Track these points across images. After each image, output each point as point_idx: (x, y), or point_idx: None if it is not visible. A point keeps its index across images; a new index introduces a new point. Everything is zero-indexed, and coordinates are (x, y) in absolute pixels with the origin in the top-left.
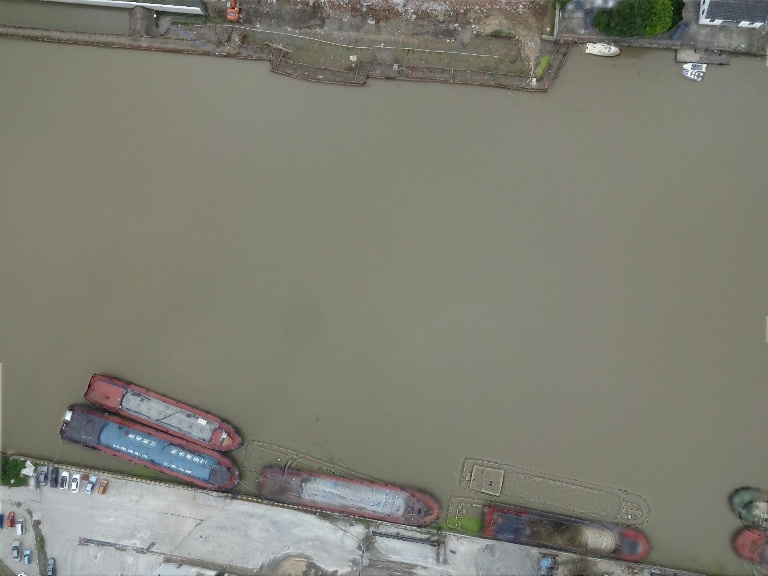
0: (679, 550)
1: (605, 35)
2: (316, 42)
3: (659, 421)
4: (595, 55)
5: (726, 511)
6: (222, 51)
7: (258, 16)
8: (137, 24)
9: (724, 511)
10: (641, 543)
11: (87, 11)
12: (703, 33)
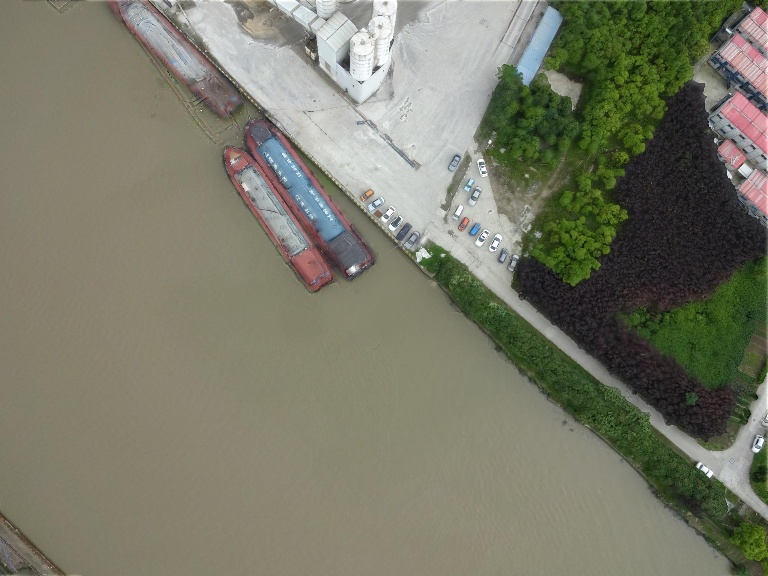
0: None
1: None
2: None
3: None
4: None
5: None
6: None
7: None
8: None
9: None
10: None
11: None
12: None
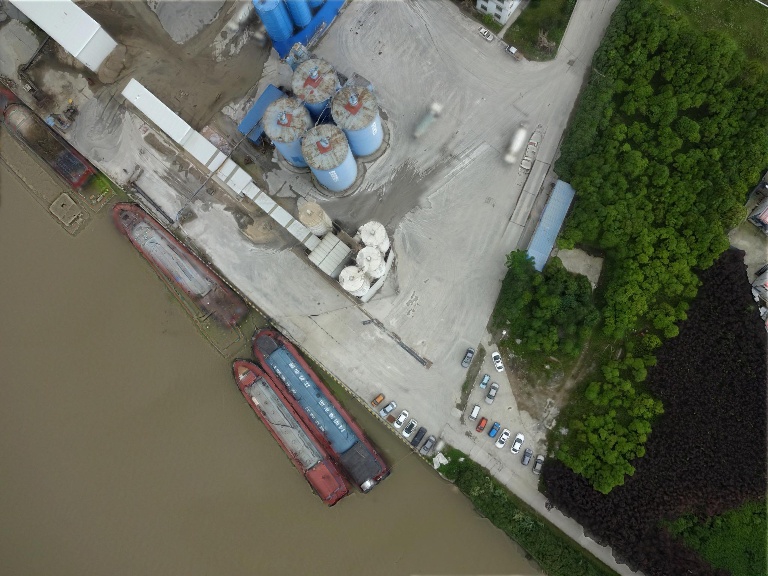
0: None
1: None
2: None
3: None
4: None
5: None
6: None
7: None
8: None
9: None
10: None
11: None
12: None
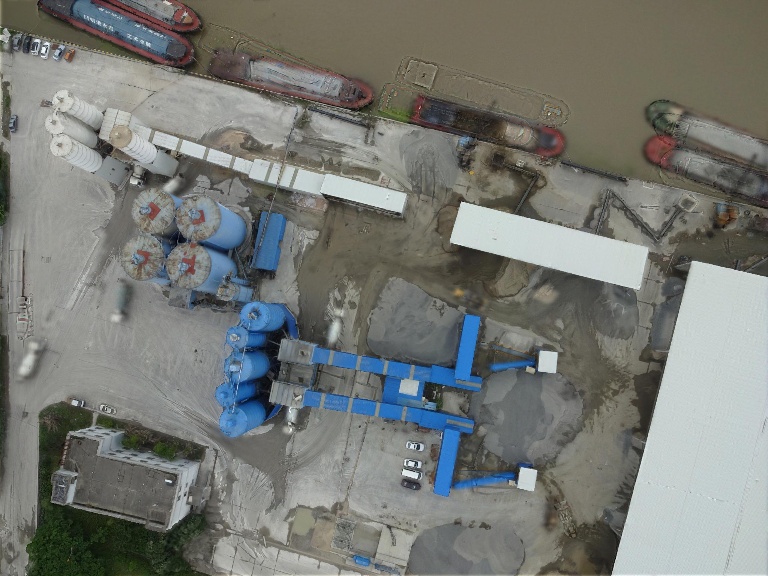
0: (593, 156)
1: None
2: None
3: (589, 36)
4: None
5: (641, 117)
6: None
7: None
8: None
9: (639, 118)
10: (557, 142)
11: None
12: None
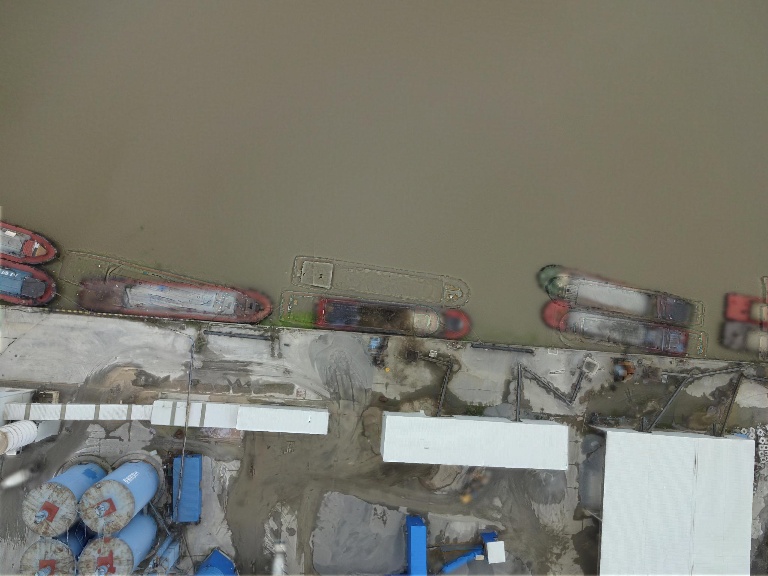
0: (498, 328)
1: None
2: None
3: (474, 211)
4: None
5: (535, 286)
6: None
7: None
8: None
9: (533, 286)
10: (463, 322)
11: None
12: None
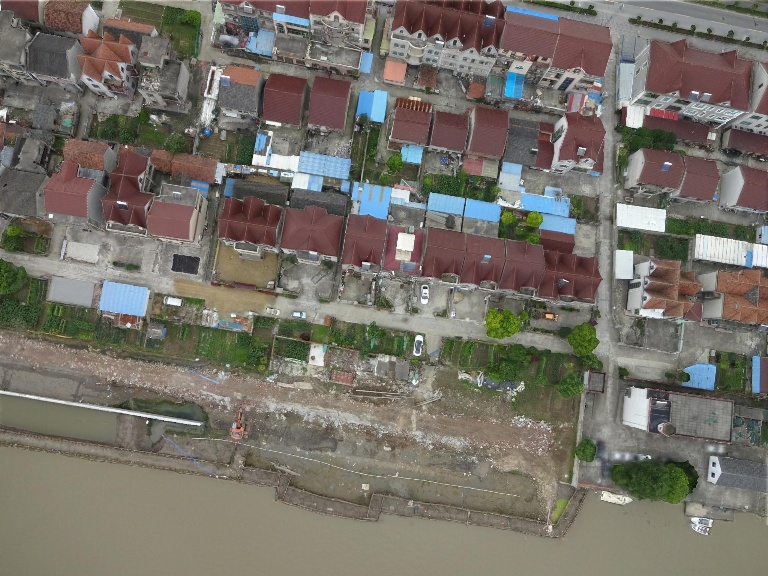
0: None
1: (621, 488)
2: (327, 466)
3: None
4: (609, 502)
5: None
6: (223, 474)
7: (265, 432)
8: (126, 434)
9: None
10: None
11: (67, 410)
12: (711, 491)
